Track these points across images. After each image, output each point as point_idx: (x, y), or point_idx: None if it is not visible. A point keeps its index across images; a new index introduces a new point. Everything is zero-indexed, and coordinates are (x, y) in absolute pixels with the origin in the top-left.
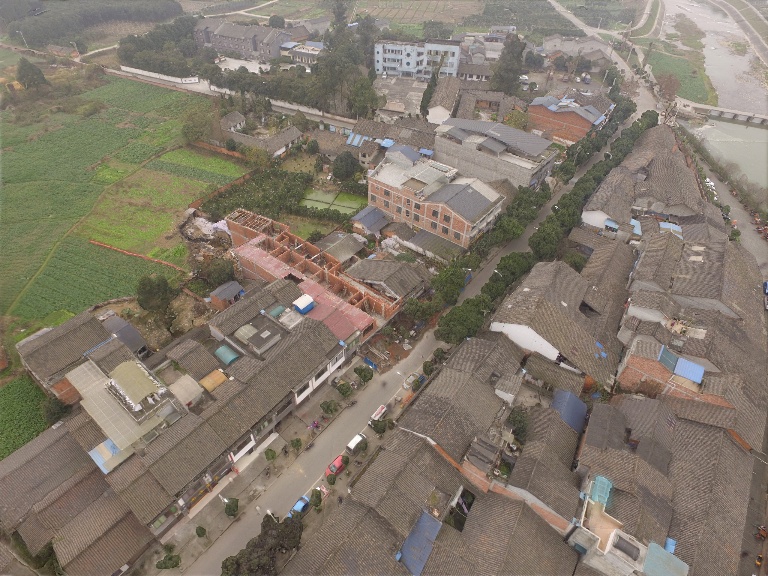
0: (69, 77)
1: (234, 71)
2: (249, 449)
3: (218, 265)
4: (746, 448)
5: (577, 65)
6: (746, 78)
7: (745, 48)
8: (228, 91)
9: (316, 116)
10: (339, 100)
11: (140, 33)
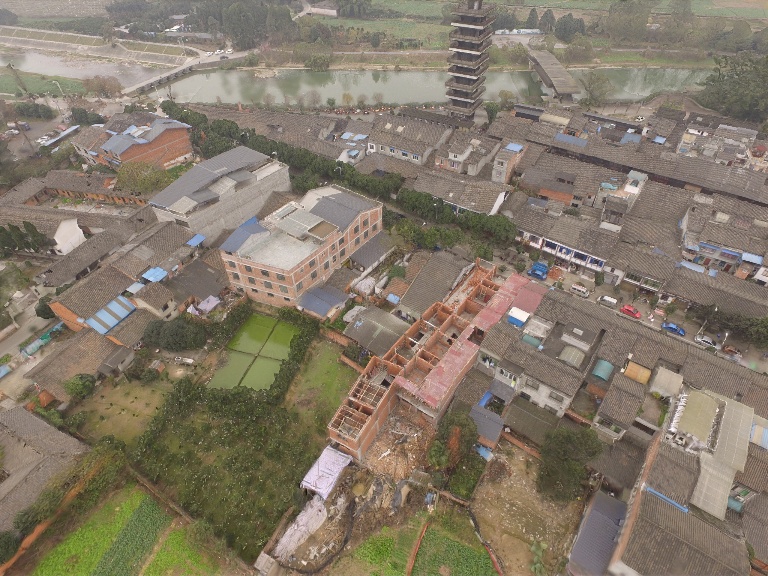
0: None
1: None
2: None
3: (467, 420)
4: None
5: None
6: (76, 64)
7: (6, 47)
8: None
9: None
10: None
11: None
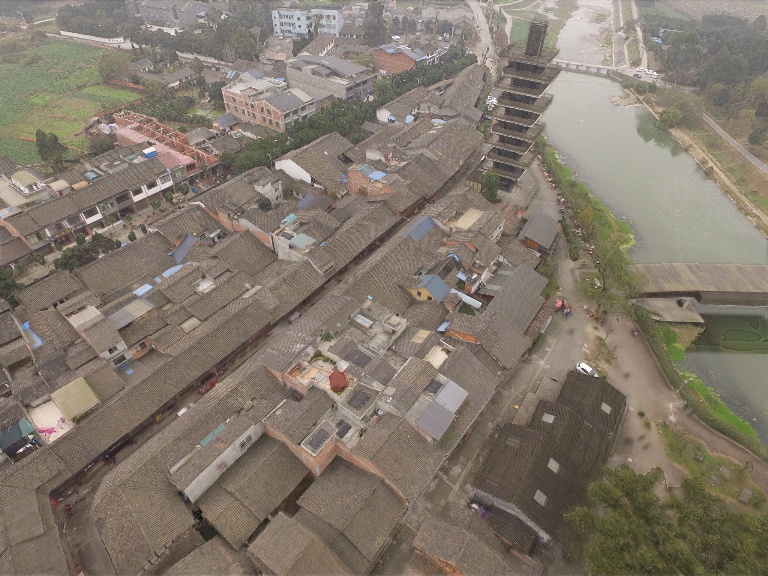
0: (16, 40)
1: None
2: (98, 220)
3: (100, 138)
4: (398, 212)
5: (442, 27)
6: (588, 39)
7: (604, 18)
8: None
9: None
10: (228, 49)
11: None
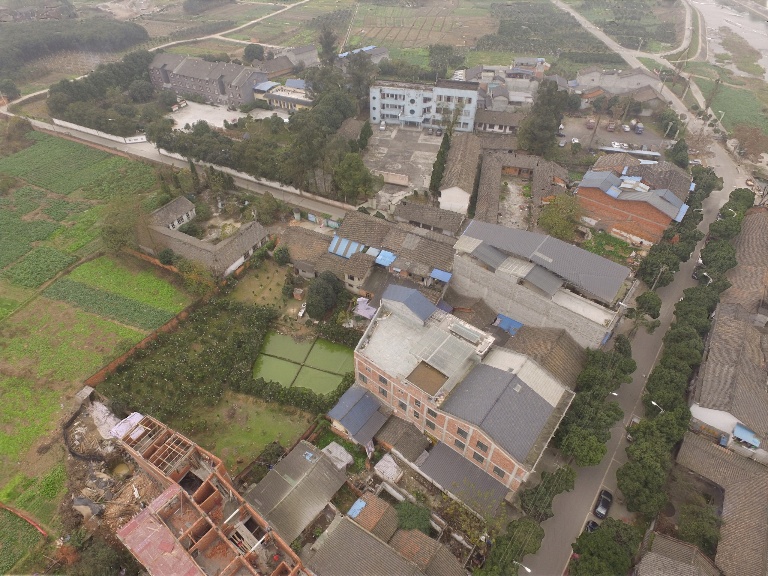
0: None
1: (185, 134)
2: None
3: (83, 575)
4: None
5: (623, 108)
6: None
7: None
8: (181, 157)
9: (292, 195)
10: (321, 178)
11: (91, 68)
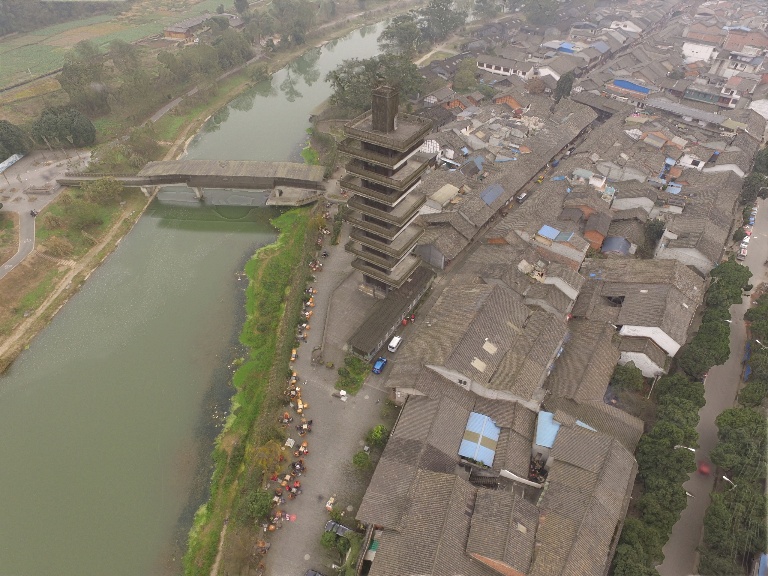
0: None
1: None
2: None
3: None
4: None
5: None
6: None
7: None
8: None
9: None
10: None
11: None
